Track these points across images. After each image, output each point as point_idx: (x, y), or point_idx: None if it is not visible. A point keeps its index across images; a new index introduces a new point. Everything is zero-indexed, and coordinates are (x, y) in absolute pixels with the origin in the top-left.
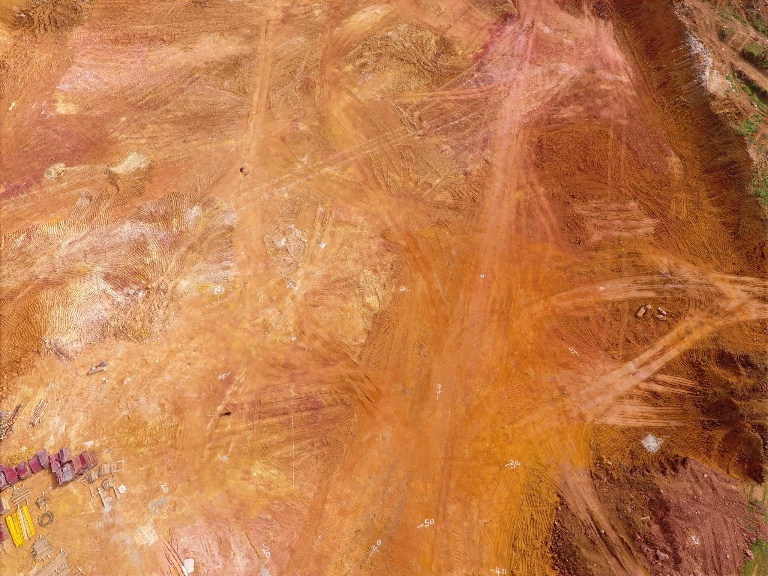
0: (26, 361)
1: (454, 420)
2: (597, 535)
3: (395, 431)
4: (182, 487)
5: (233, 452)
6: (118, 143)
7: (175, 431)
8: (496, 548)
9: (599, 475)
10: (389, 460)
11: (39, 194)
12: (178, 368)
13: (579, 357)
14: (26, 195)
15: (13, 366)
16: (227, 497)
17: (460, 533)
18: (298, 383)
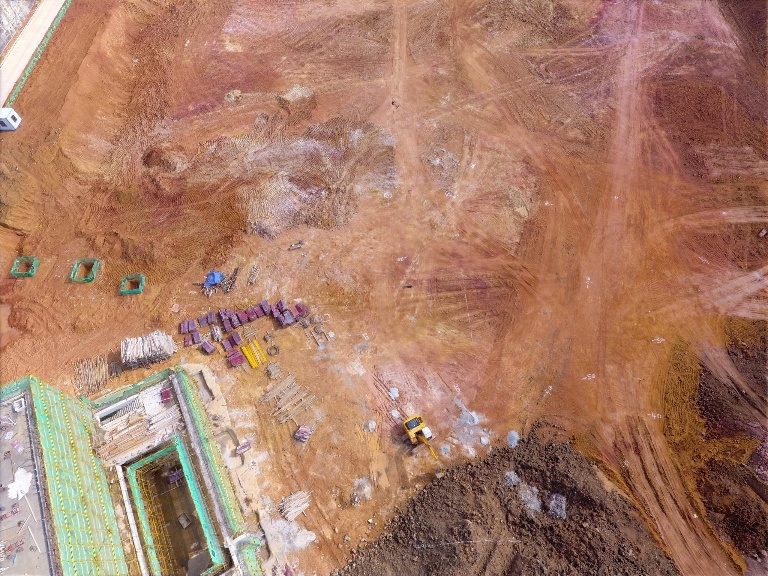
0: (237, 236)
1: (604, 304)
2: (739, 394)
3: (554, 309)
4: (380, 337)
5: (419, 315)
6: (283, 77)
7: (368, 296)
8: (651, 399)
9: (736, 352)
10: (552, 329)
11: (223, 113)
12: (363, 250)
13: (709, 264)
14: (212, 113)
15: (227, 239)
16: (418, 346)
17: (619, 386)
18: (466, 268)
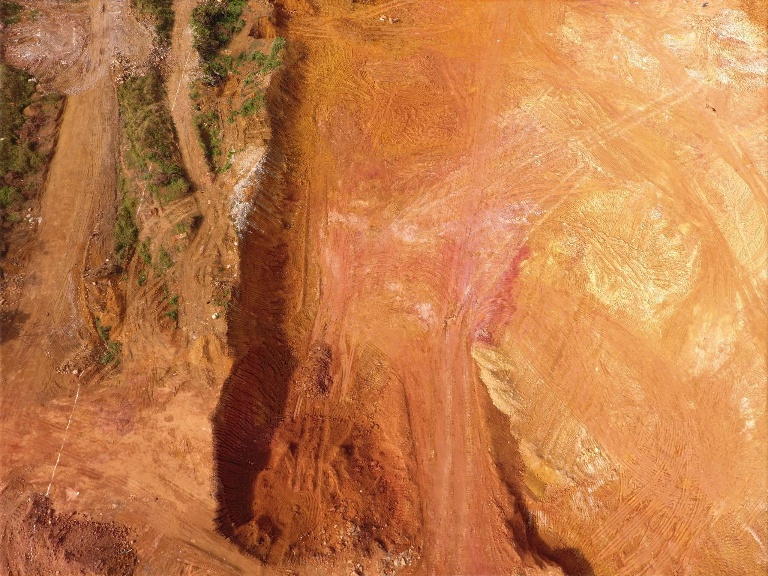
0: (745, 7)
1: None
2: None
3: None
4: None
5: None
6: None
7: None
8: None
9: None
10: None
11: None
12: (663, 6)
13: (439, 5)
14: None
15: None
16: None
17: None
18: None
